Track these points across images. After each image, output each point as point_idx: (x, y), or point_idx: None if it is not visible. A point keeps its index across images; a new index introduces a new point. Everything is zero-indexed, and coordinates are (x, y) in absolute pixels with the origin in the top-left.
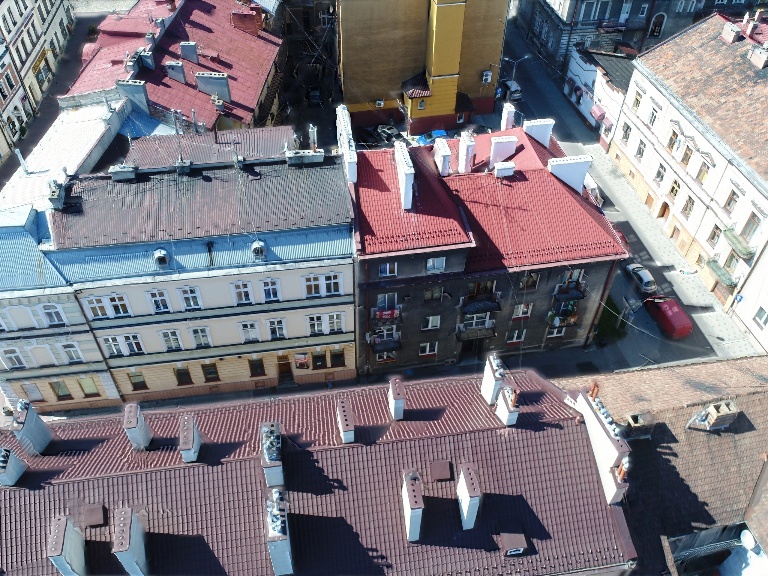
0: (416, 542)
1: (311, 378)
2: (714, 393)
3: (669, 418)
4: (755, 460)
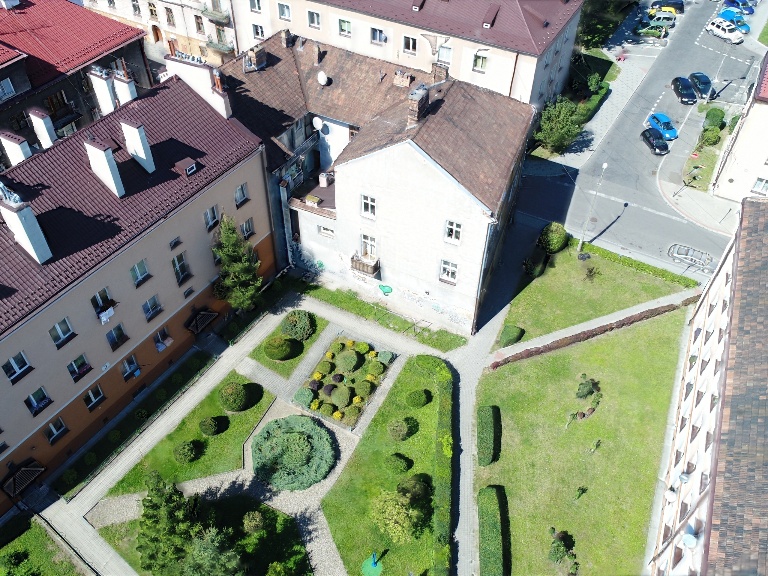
0: (125, 196)
1: None
2: None
3: (231, 72)
4: (293, 77)
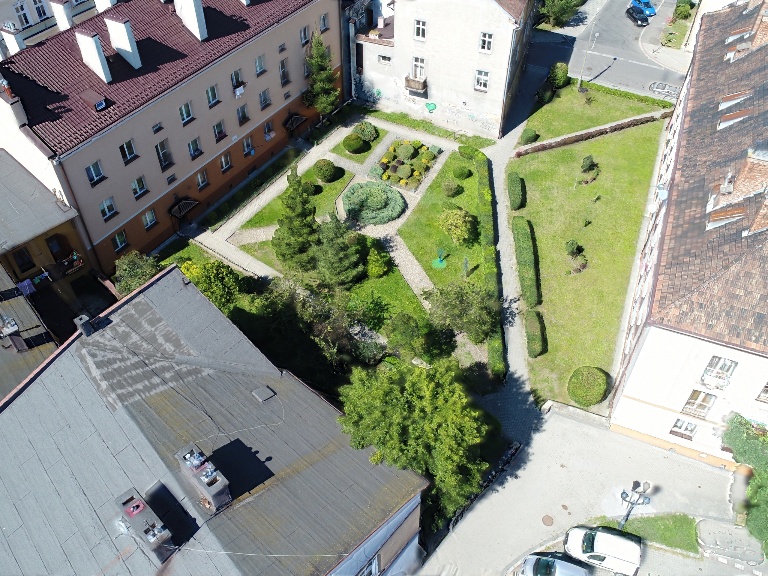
0: (250, 6)
1: None
2: None
3: None
4: None
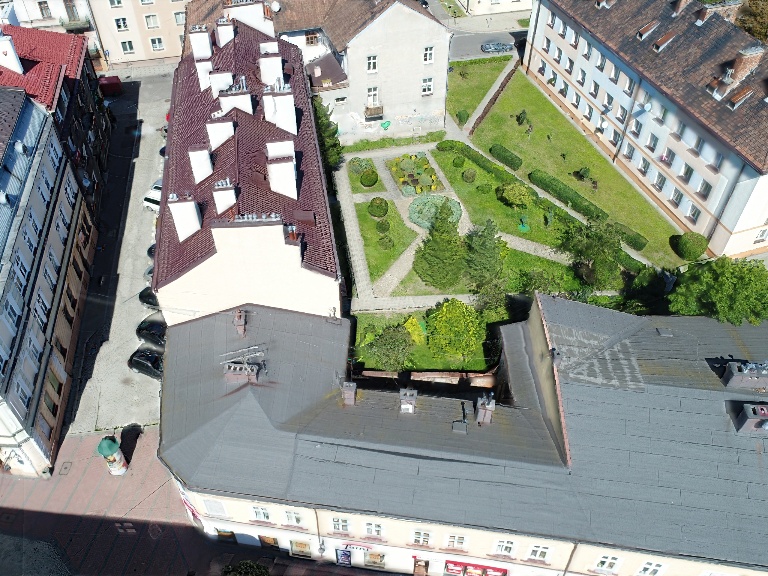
0: None
1: (91, 254)
2: (218, 6)
3: None
4: None
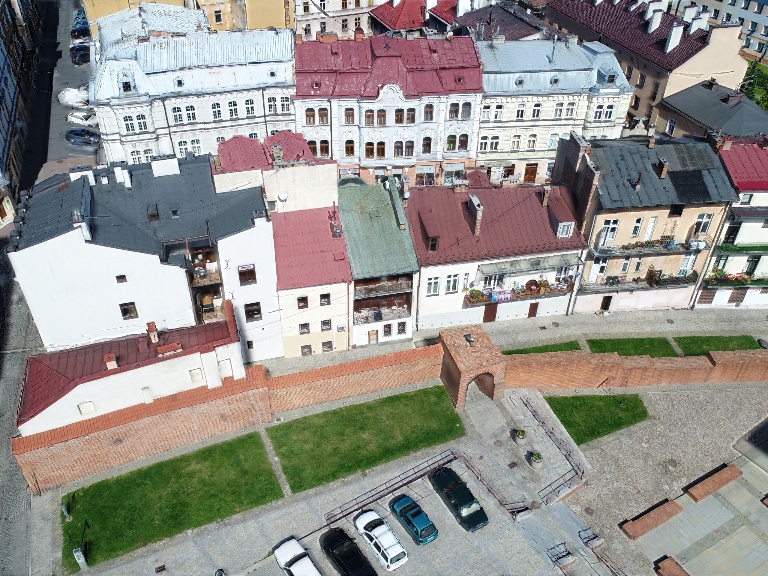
0: None
1: None
2: None
3: None
4: None
